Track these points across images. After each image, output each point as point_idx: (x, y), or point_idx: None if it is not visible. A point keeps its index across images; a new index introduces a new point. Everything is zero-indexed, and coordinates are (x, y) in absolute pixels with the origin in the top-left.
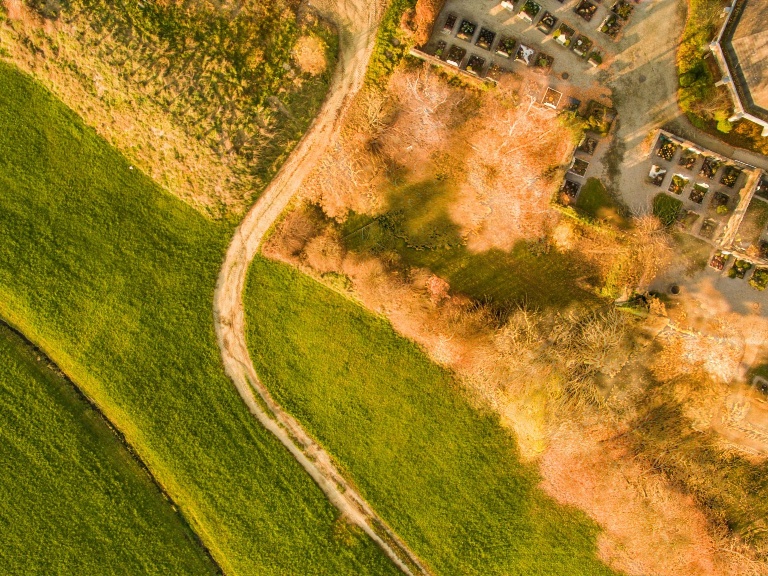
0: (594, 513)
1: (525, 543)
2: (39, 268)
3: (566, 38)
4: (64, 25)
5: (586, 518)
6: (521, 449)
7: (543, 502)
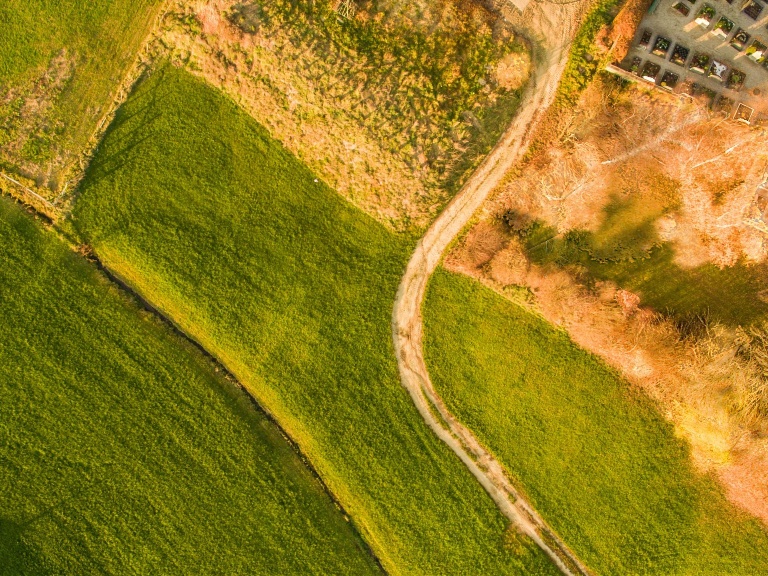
0: (763, 523)
1: (692, 552)
2: (220, 280)
3: (760, 55)
4: (262, 40)
5: (754, 528)
6: (695, 460)
7: (712, 512)
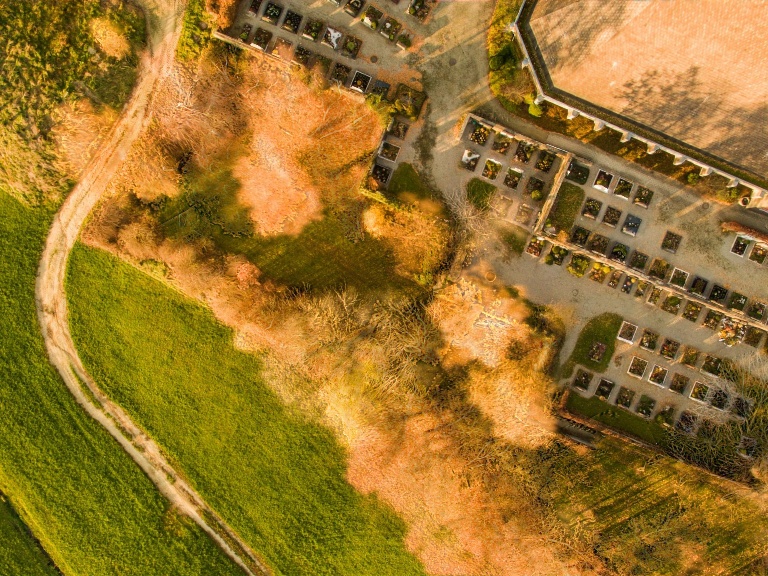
0: (426, 504)
1: (358, 534)
2: None
3: (372, 21)
4: None
5: (418, 509)
6: None
7: (375, 493)
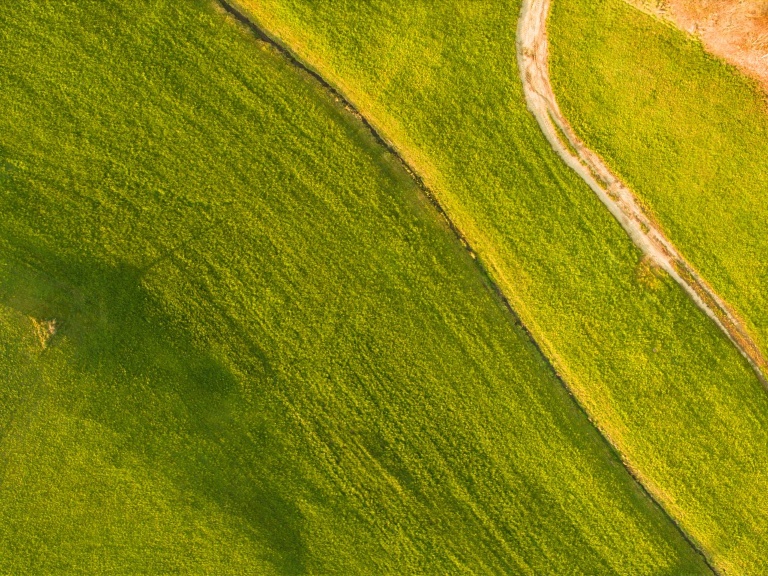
0: None
1: None
2: (339, 3)
3: None
4: None
5: None
6: None
7: None
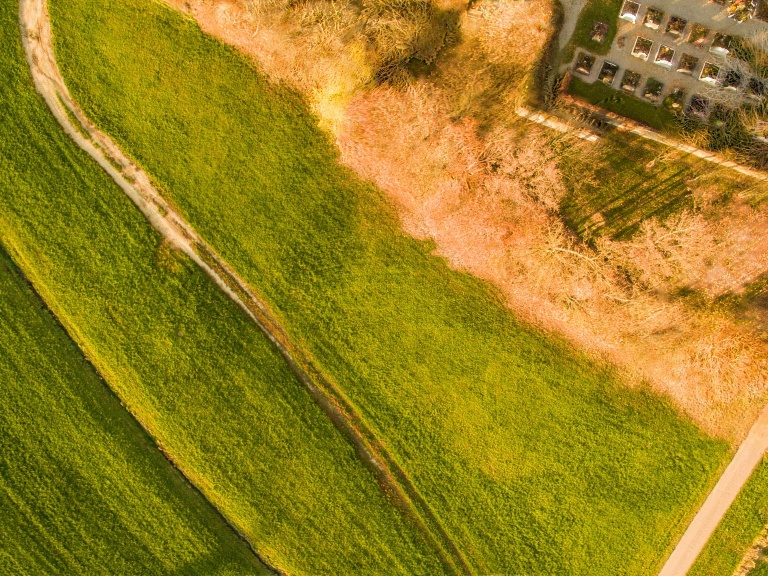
0: (426, 224)
1: (357, 263)
2: None
3: None
4: None
5: (419, 231)
6: None
7: (373, 216)
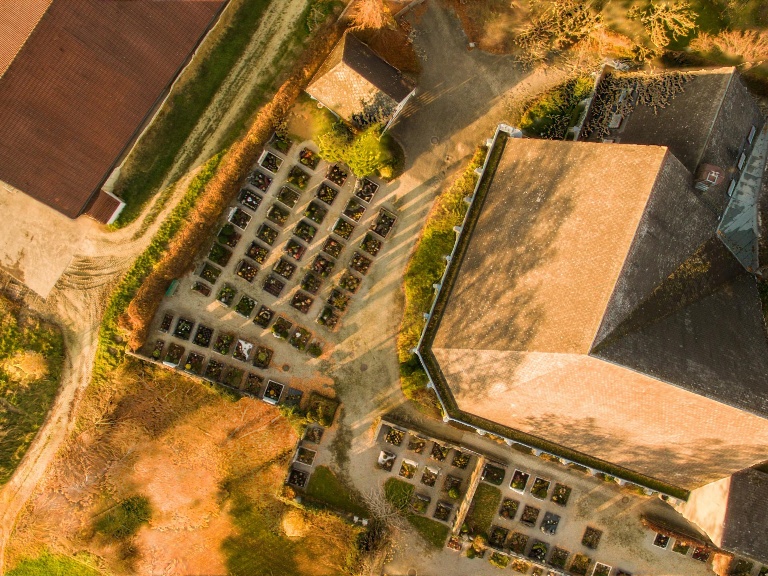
0: None
1: None
2: None
3: (281, 334)
4: None
5: None
6: None
7: None
